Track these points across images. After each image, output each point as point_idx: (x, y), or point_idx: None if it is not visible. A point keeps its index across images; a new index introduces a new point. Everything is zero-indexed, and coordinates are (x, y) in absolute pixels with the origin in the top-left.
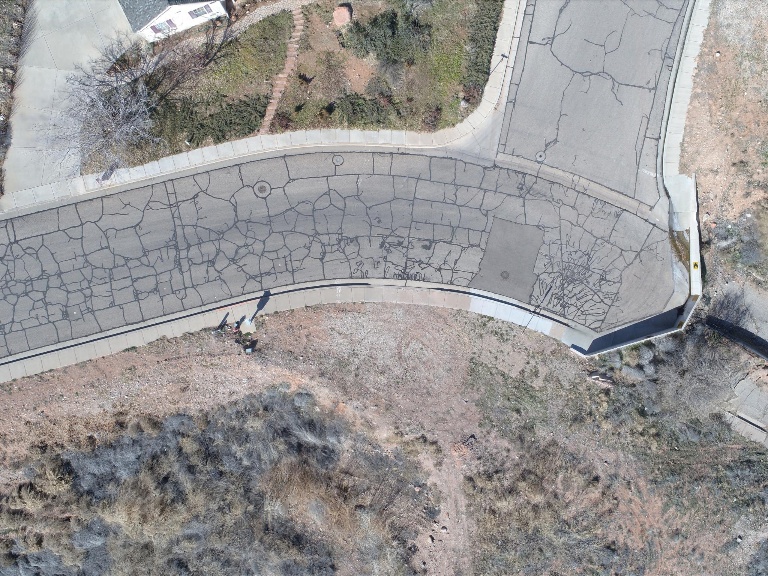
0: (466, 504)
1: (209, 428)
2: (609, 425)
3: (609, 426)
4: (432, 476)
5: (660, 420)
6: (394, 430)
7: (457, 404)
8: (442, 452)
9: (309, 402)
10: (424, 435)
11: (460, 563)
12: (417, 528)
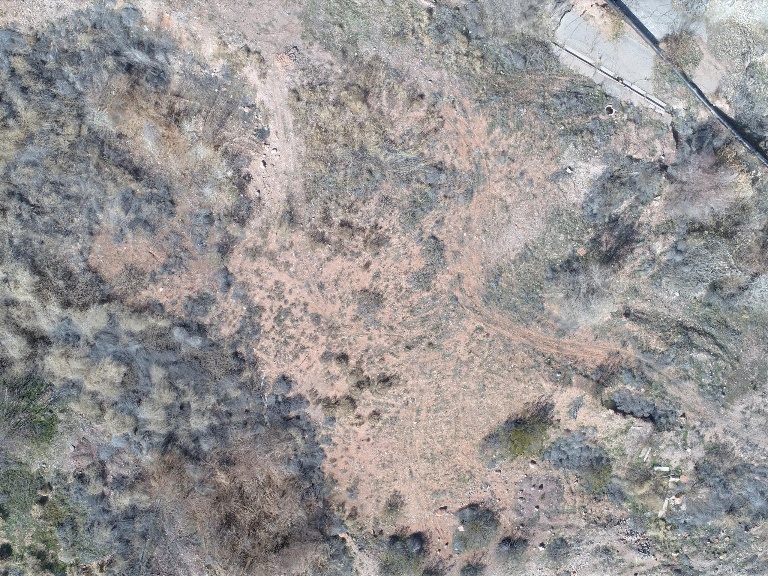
0: (293, 120)
1: (40, 47)
2: (431, 41)
3: (432, 45)
4: (258, 92)
5: (485, 44)
6: (217, 40)
7: (279, 16)
8: (265, 63)
9: (137, 21)
10: (247, 46)
11: (292, 186)
12: (250, 154)
